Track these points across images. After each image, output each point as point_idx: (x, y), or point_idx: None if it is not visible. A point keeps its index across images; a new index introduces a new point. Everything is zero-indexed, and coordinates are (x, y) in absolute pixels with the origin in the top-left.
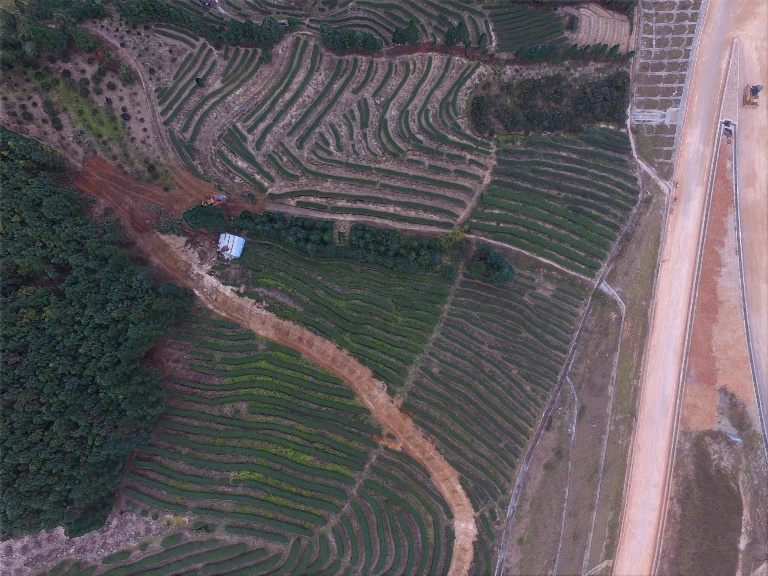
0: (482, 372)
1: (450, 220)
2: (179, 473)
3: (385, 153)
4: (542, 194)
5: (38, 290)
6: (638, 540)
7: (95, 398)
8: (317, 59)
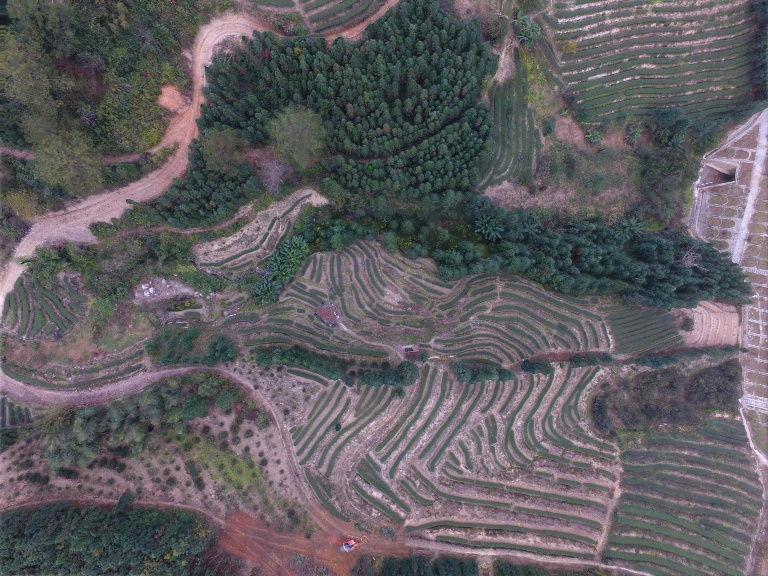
0: None
1: (590, 550)
2: None
3: (512, 463)
4: (673, 507)
5: None
6: None
7: None
8: (447, 385)
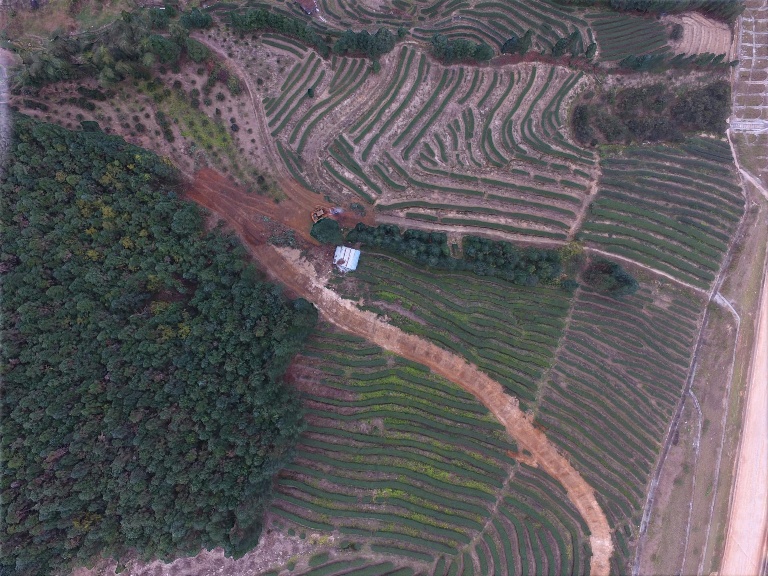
0: (608, 386)
1: (562, 232)
2: (324, 491)
3: (488, 163)
4: (650, 205)
5: (169, 306)
6: (743, 552)
7: (247, 417)
8: (424, 69)
